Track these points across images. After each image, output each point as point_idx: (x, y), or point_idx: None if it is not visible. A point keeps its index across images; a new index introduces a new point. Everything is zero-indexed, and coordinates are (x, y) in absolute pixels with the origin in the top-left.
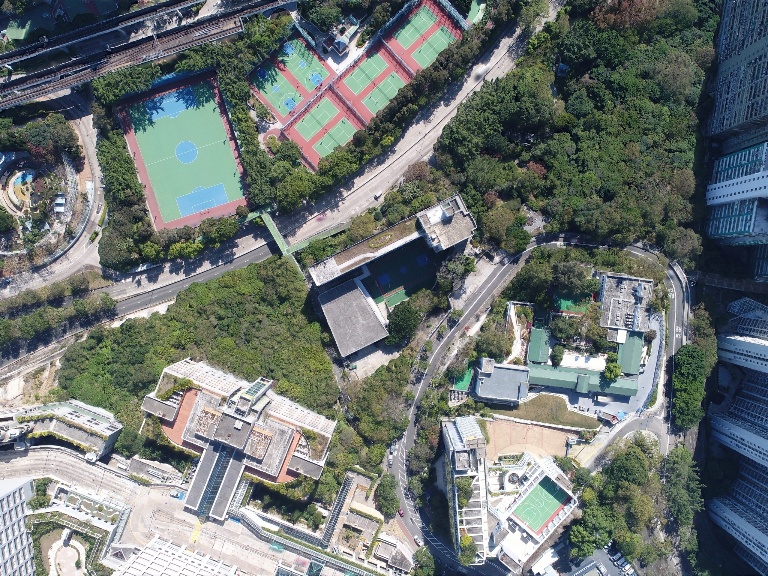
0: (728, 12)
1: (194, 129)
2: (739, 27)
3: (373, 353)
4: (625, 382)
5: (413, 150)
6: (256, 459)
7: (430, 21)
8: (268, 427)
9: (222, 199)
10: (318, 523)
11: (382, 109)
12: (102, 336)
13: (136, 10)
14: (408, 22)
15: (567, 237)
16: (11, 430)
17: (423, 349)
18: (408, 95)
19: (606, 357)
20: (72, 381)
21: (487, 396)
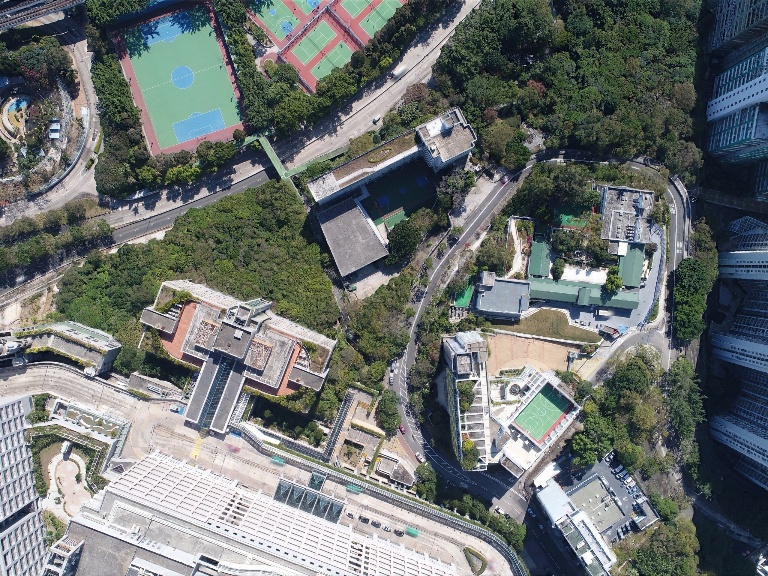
0: None
1: (190, 54)
2: None
3: (373, 274)
4: (626, 295)
5: (411, 73)
6: (256, 371)
7: None
8: (268, 338)
9: (219, 125)
10: (319, 437)
11: (380, 31)
12: (99, 262)
13: None
14: None
15: (567, 154)
16: (9, 343)
17: (423, 267)
18: (406, 14)
19: (607, 271)
20: (70, 304)
21: (488, 310)
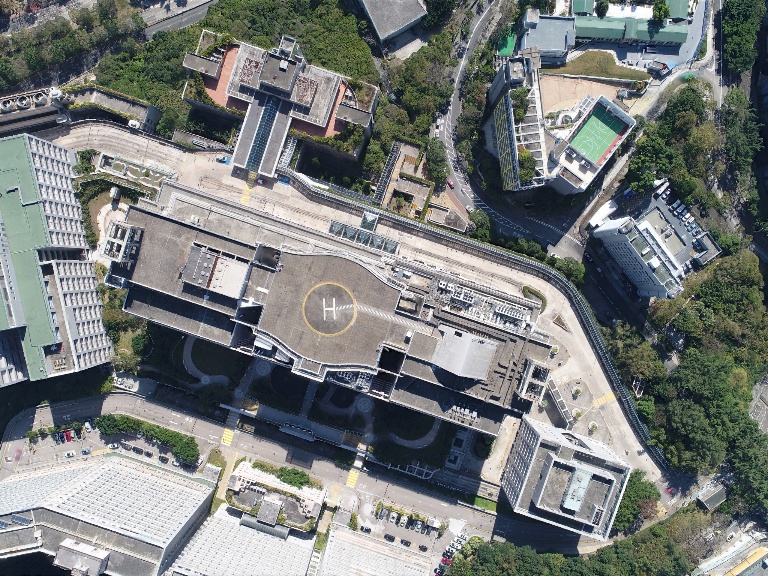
0: None
1: None
2: None
3: (411, 42)
4: (674, 27)
5: None
6: (303, 110)
7: None
8: (313, 76)
9: None
10: (368, 184)
11: None
12: (134, 53)
13: None
14: None
15: None
16: (53, 91)
17: (463, 23)
18: None
19: None
20: (108, 86)
21: None
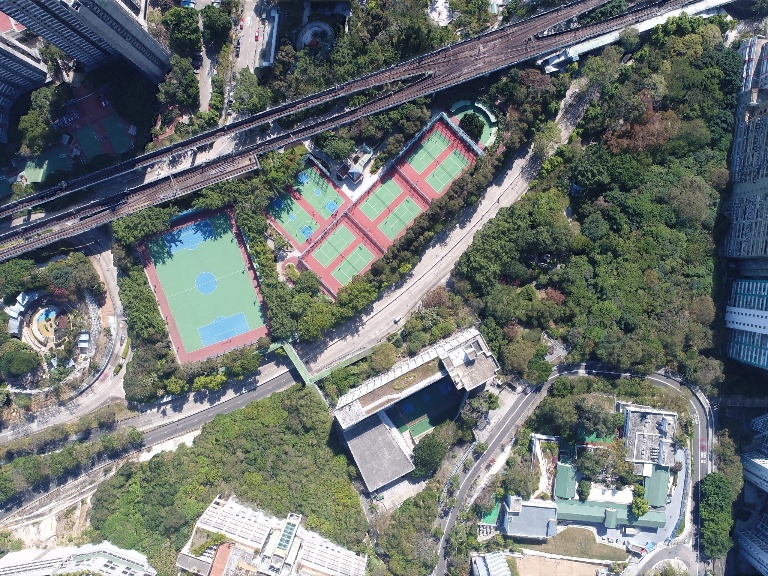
0: (741, 133)
1: (213, 260)
2: (753, 153)
3: (400, 483)
4: (653, 515)
5: (430, 273)
6: None
7: (443, 145)
8: None
9: (243, 328)
10: None
11: None
12: (131, 471)
13: (152, 150)
14: (421, 147)
15: (588, 365)
16: None
17: (450, 482)
18: (424, 225)
19: (632, 488)
20: (104, 522)
21: (516, 534)
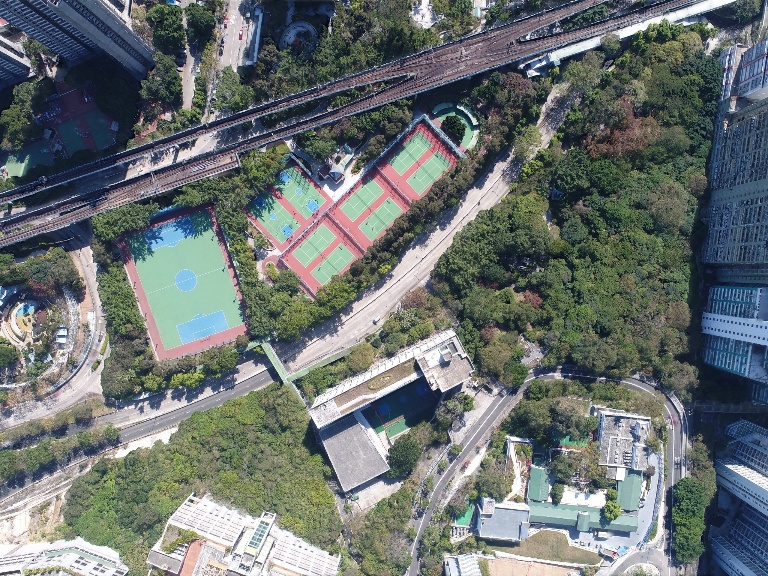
0: (719, 140)
1: (193, 258)
2: (730, 160)
3: (375, 484)
4: (625, 519)
5: (410, 274)
6: None
7: (424, 147)
8: None
9: (222, 326)
10: None
11: None
12: (106, 468)
13: (133, 146)
14: (402, 148)
15: (564, 369)
16: None
17: (424, 483)
18: (404, 226)
19: (606, 492)
20: (78, 518)
21: (488, 536)
